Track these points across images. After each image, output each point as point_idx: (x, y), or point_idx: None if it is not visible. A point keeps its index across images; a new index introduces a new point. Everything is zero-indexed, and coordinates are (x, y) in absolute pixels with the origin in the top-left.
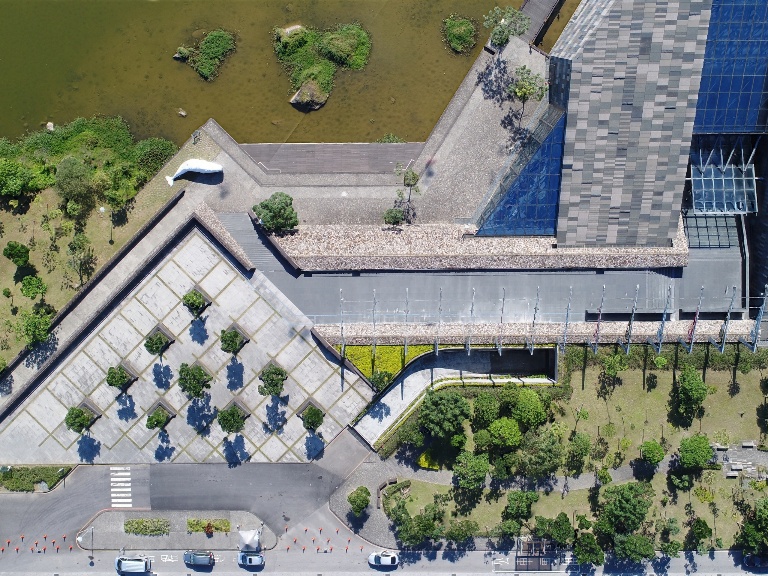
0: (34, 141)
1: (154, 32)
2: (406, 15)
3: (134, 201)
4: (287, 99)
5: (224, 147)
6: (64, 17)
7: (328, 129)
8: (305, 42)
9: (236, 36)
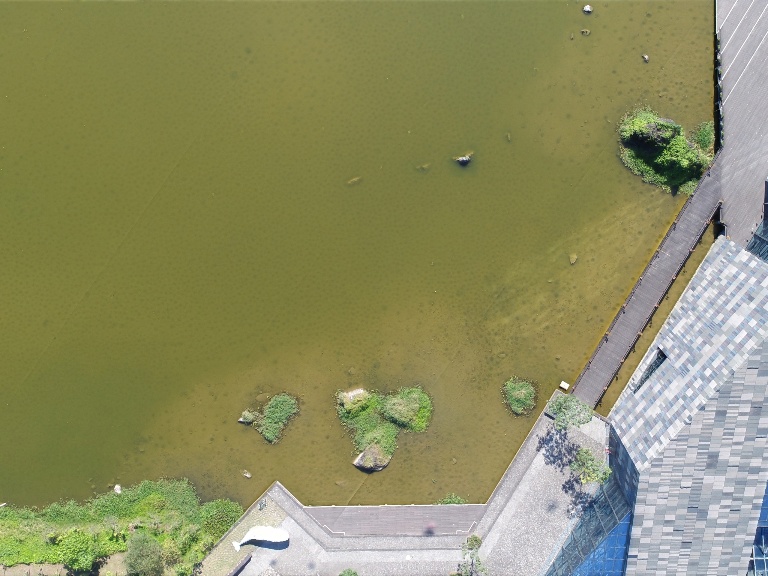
0: (102, 504)
1: (219, 396)
2: (467, 378)
3: (201, 566)
4: (350, 460)
5: (289, 511)
6: (130, 381)
7: (391, 489)
8: (368, 406)
9: (299, 400)
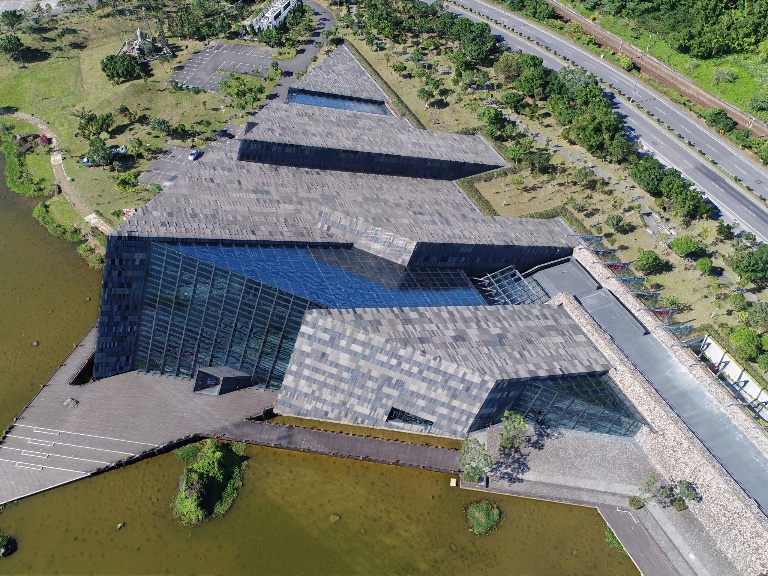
0: None
1: None
2: (492, 573)
3: None
4: None
5: None
6: None
7: None
8: None
9: None
